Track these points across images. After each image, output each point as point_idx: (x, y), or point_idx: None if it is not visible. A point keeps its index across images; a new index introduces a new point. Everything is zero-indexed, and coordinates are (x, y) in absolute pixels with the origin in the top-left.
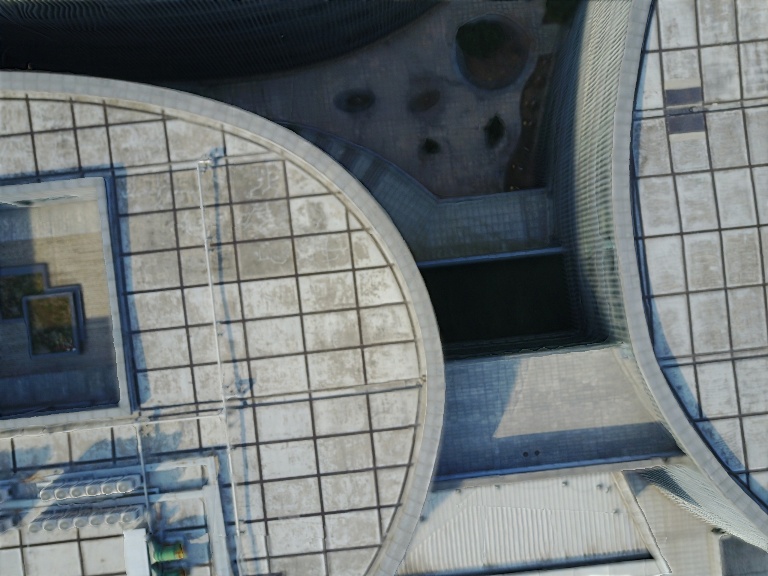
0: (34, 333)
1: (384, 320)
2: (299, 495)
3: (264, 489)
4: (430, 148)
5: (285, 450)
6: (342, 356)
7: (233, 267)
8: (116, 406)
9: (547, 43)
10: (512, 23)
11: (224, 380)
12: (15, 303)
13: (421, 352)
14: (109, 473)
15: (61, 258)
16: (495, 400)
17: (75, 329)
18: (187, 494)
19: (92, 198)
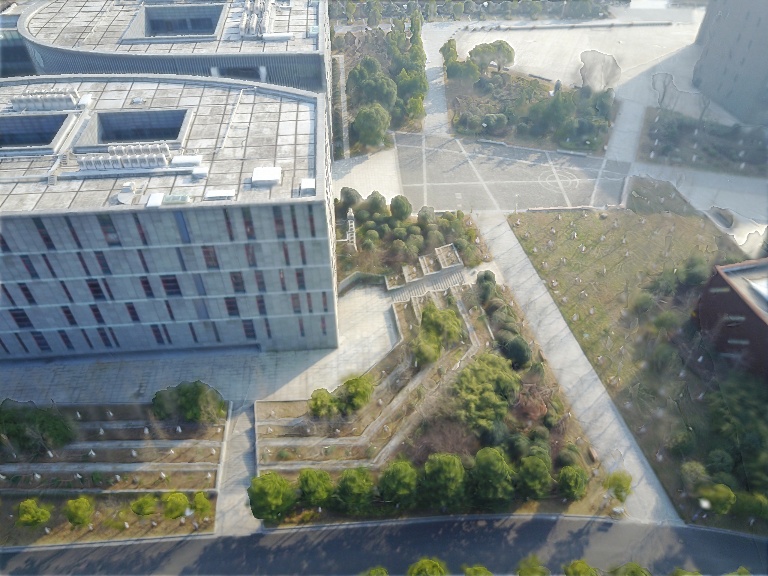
0: None
1: None
2: None
3: None
4: None
5: None
6: None
7: None
8: (146, 8)
9: None
10: None
11: None
12: None
13: None
14: (156, 0)
15: None
16: None
17: None
18: None
19: None
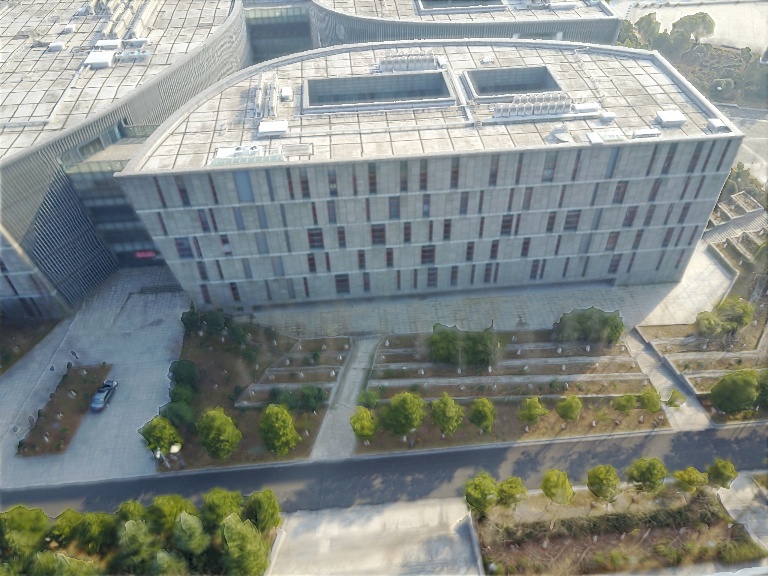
0: None
1: None
2: None
3: None
4: None
5: None
6: None
7: None
8: None
9: None
10: None
11: None
12: None
13: None
14: None
15: None
16: None
17: None
18: None
19: None
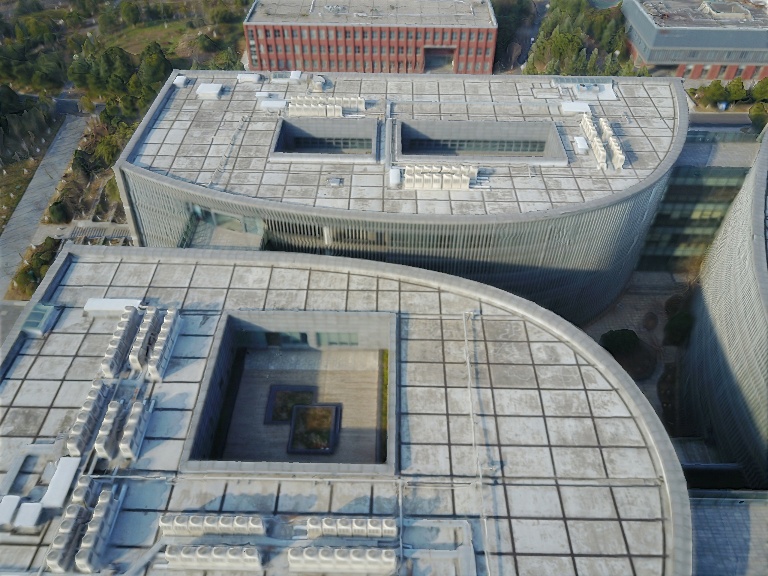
0: (296, 432)
1: (616, 428)
2: (554, 572)
3: (517, 562)
4: None
5: (536, 526)
6: (583, 452)
7: (487, 378)
8: (384, 463)
9: (669, 356)
10: (640, 340)
11: (478, 459)
12: (286, 410)
13: (654, 457)
14: None
15: (330, 384)
16: (725, 545)
17: (332, 433)
18: (442, 552)
19: (365, 347)
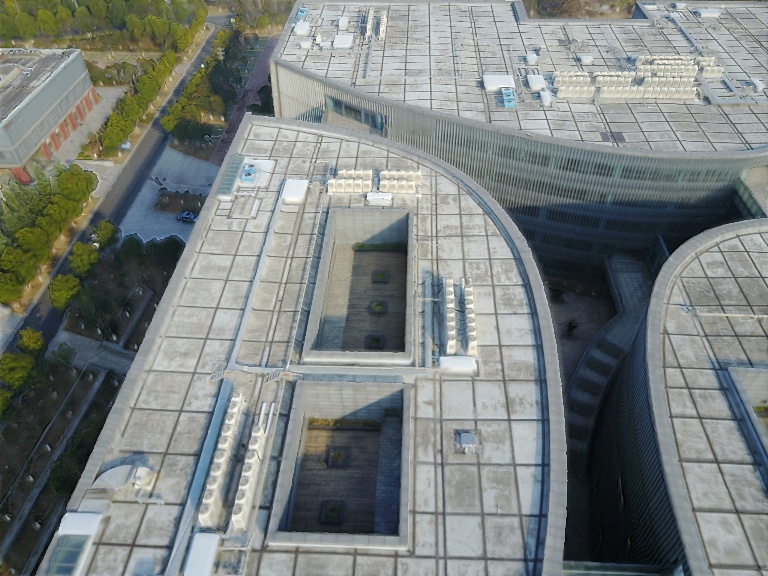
0: None
1: None
2: None
3: None
4: (573, 326)
5: None
6: None
7: None
8: None
9: None
10: None
11: None
12: None
13: None
14: None
15: None
16: None
17: None
18: None
19: None
